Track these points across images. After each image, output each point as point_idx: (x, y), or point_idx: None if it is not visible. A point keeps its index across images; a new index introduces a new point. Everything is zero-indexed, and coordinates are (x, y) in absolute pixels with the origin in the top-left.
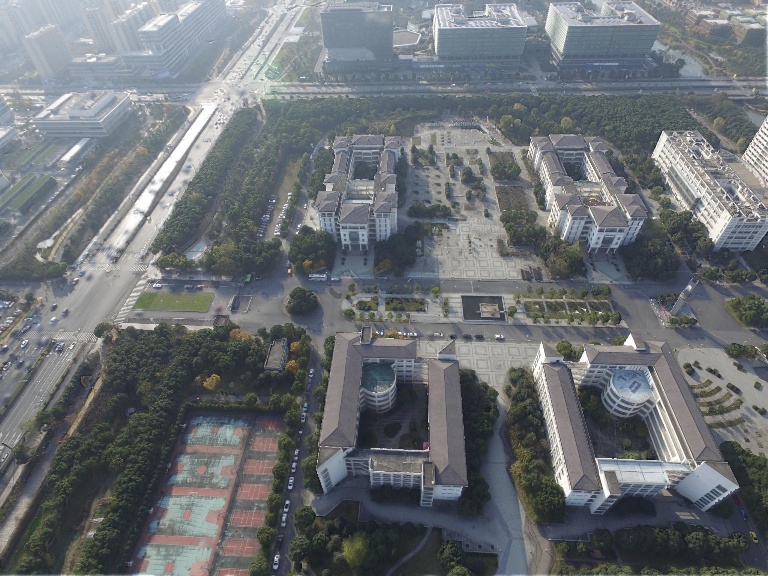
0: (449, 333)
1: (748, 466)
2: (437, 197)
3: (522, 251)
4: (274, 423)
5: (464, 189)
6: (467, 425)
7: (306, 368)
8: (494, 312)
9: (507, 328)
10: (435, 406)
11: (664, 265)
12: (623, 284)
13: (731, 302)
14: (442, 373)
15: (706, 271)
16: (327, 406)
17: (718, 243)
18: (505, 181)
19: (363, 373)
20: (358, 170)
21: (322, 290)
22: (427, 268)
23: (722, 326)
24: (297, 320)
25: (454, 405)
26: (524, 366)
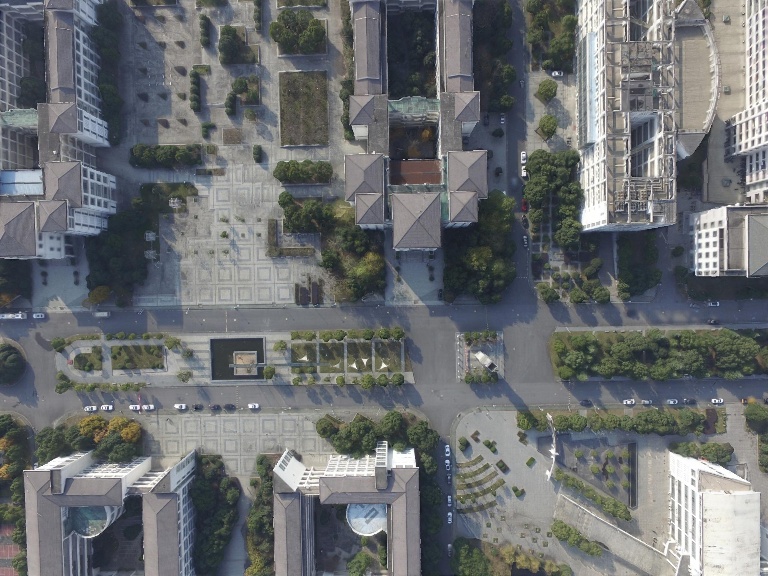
0: (193, 402)
1: (465, 575)
2: (179, 109)
3: (303, 244)
4: (10, 530)
5: (225, 84)
6: (199, 542)
7: (29, 461)
8: (251, 366)
9: (265, 391)
10: (149, 556)
11: (488, 286)
12: (430, 306)
13: (554, 346)
14: (154, 518)
15: (545, 291)
16: (29, 572)
17: (588, 230)
18: (298, 55)
19: (71, 511)
20: (25, 50)
21: (25, 337)
22: (165, 286)
23: (531, 376)
24: (3, 390)
25: (169, 554)
26: (278, 446)
